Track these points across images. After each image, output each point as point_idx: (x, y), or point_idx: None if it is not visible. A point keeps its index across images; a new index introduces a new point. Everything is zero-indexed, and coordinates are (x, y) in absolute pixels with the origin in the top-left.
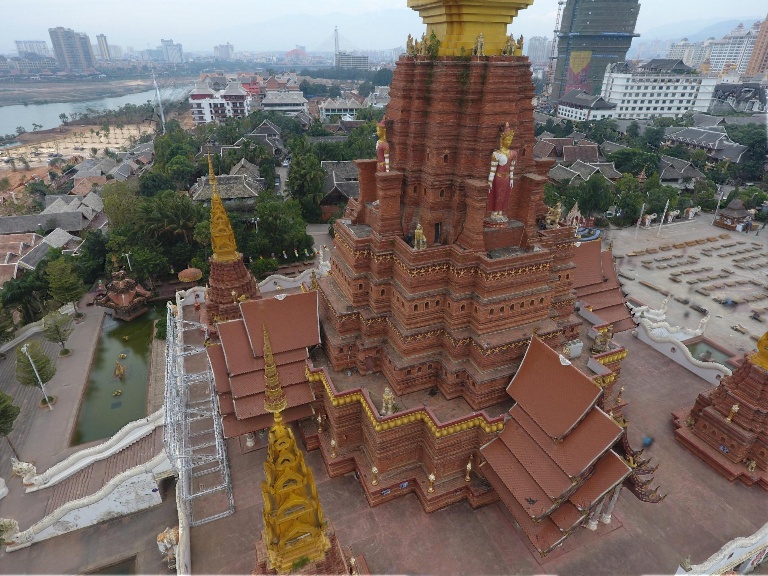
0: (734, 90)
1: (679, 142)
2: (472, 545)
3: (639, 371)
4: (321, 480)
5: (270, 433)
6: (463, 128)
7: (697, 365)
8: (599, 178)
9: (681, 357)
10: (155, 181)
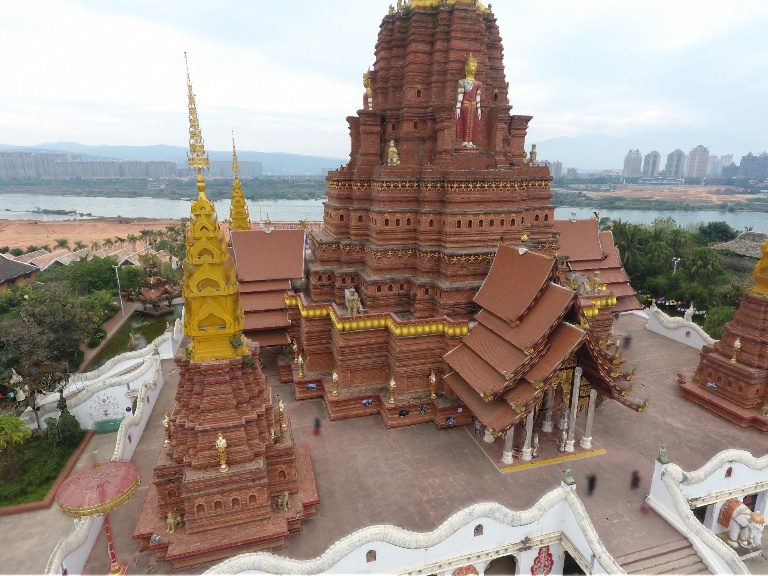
0: None
1: None
2: None
3: (425, 474)
4: None
5: None
6: None
7: None
8: None
9: None
10: (709, 228)
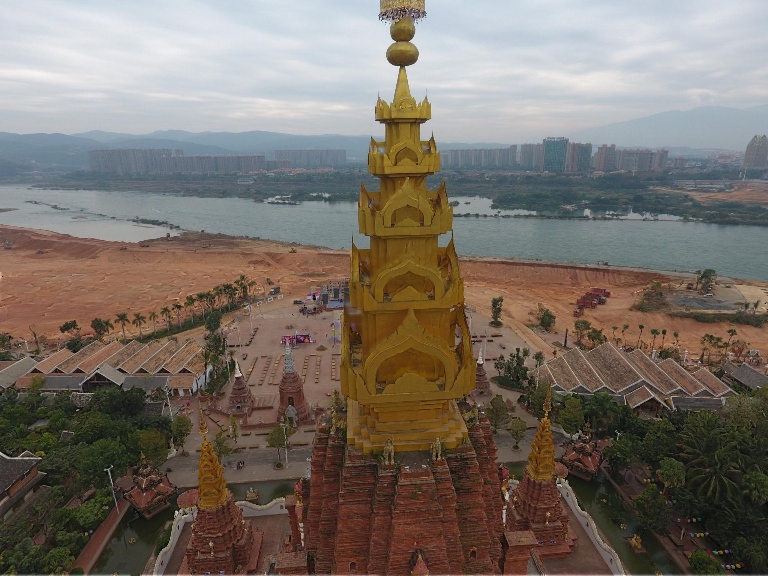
0: None
1: None
2: None
3: None
4: None
5: None
6: None
7: None
8: None
9: None
10: None
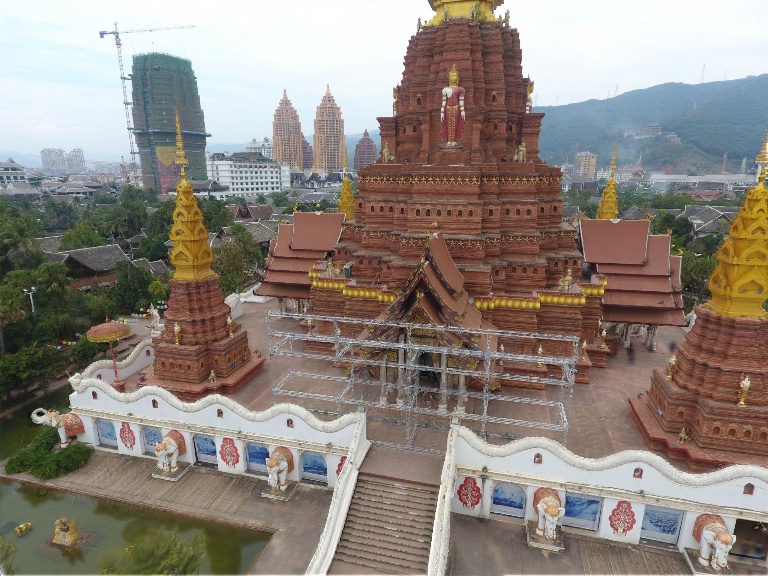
0: (296, 176)
1: (307, 204)
2: (642, 364)
3: None
4: (543, 395)
5: (762, 189)
6: (510, 77)
7: None
8: None
9: None
10: None
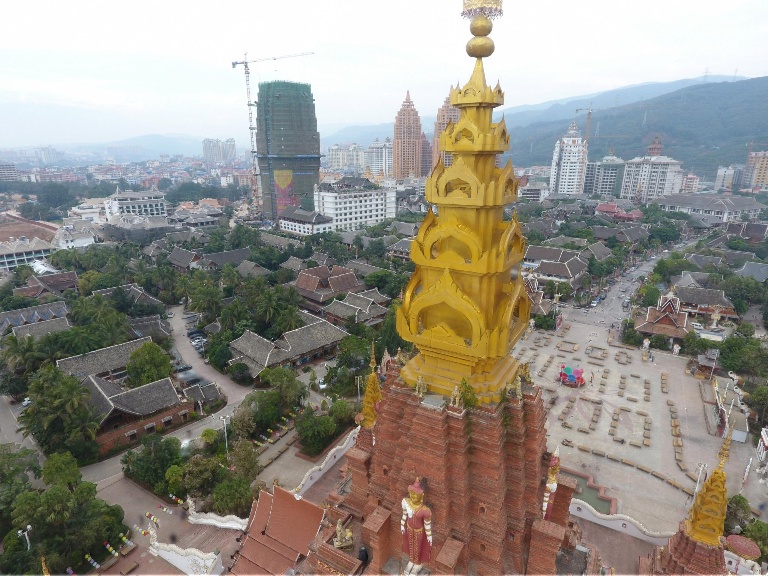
0: (404, 197)
1: (400, 252)
2: None
3: None
4: None
5: None
6: (514, 470)
7: (604, 519)
8: (394, 320)
9: (588, 514)
10: None
